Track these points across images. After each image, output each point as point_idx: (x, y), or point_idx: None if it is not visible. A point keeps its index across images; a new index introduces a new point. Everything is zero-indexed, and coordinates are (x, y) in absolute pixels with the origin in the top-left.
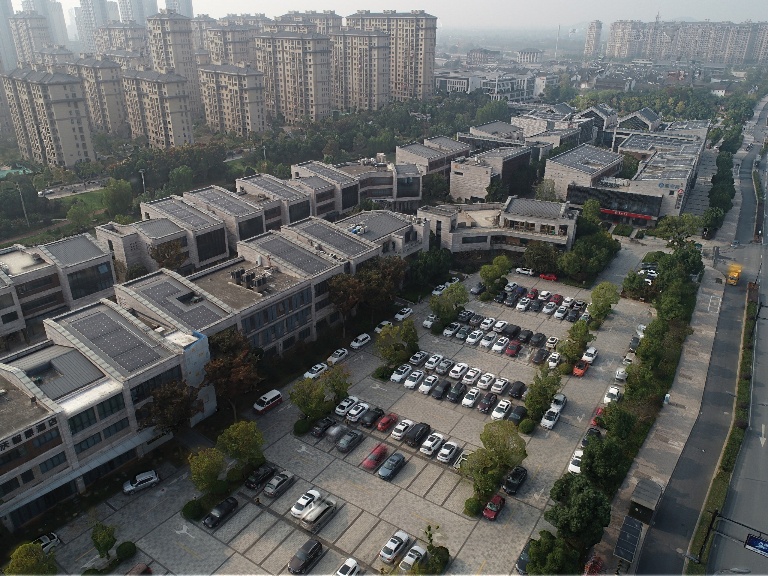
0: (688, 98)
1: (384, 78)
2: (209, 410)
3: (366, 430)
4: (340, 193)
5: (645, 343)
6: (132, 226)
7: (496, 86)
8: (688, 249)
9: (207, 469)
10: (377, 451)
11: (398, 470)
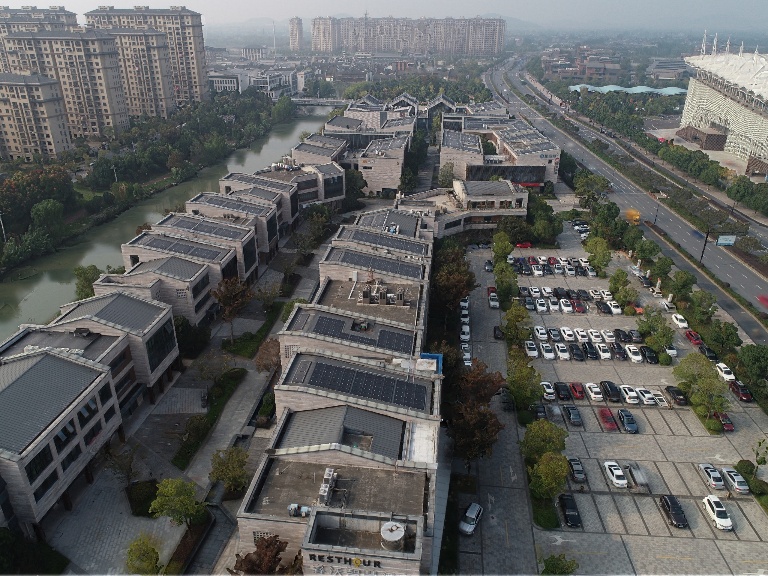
0: (438, 85)
1: (168, 80)
2: None
3: (568, 403)
4: (289, 202)
5: (683, 275)
6: (151, 272)
7: (268, 83)
8: (609, 203)
9: (568, 471)
10: (599, 415)
11: None
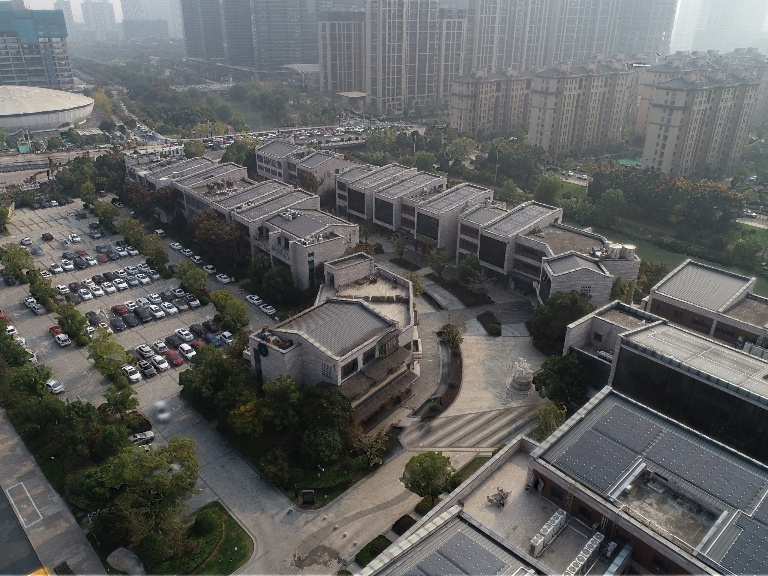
0: None
1: None
2: (165, 221)
3: None
4: (479, 238)
5: None
6: None
7: None
8: None
9: None
10: None
11: (65, 258)
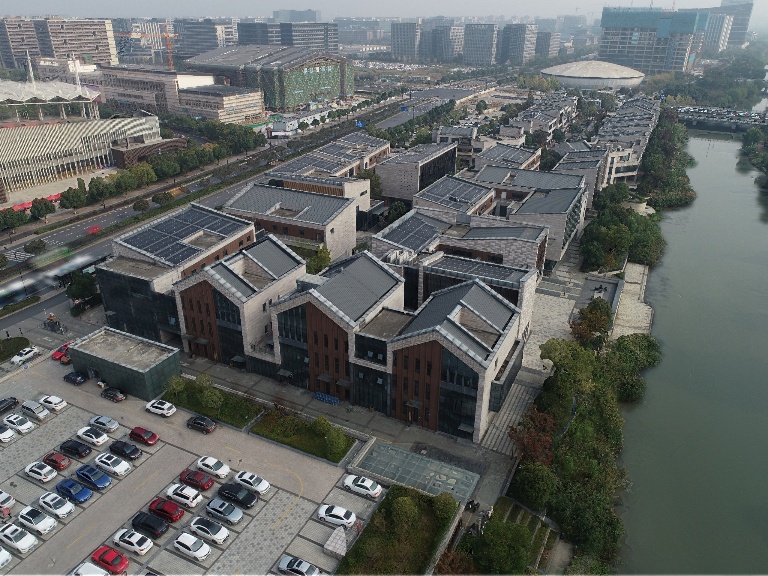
0: None
1: None
2: None
3: None
4: None
5: None
6: None
7: None
8: None
9: None
10: None
11: None
